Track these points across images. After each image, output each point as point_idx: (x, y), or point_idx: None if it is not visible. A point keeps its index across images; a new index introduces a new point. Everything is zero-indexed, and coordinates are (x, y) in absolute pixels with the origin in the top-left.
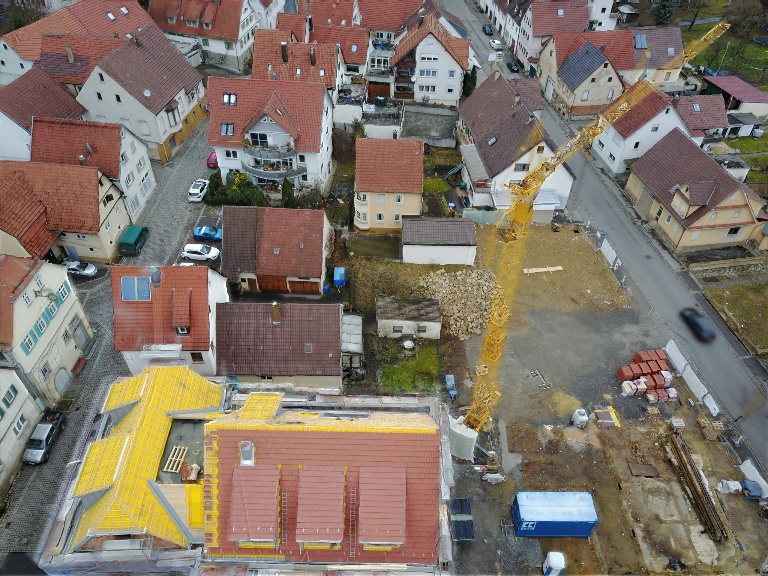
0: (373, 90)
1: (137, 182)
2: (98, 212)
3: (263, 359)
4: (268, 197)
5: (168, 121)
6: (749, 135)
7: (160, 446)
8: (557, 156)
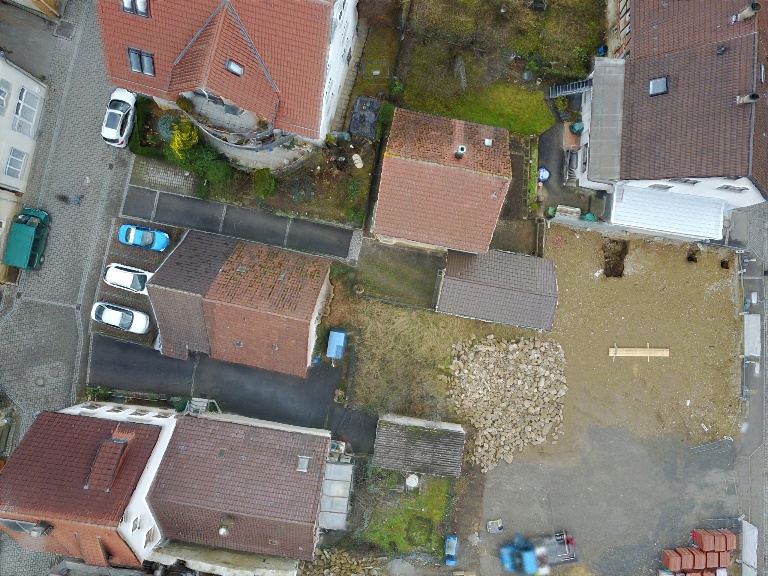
0: None
1: (6, 130)
2: None
3: (216, 538)
4: (234, 163)
5: None
6: None
7: None
8: None
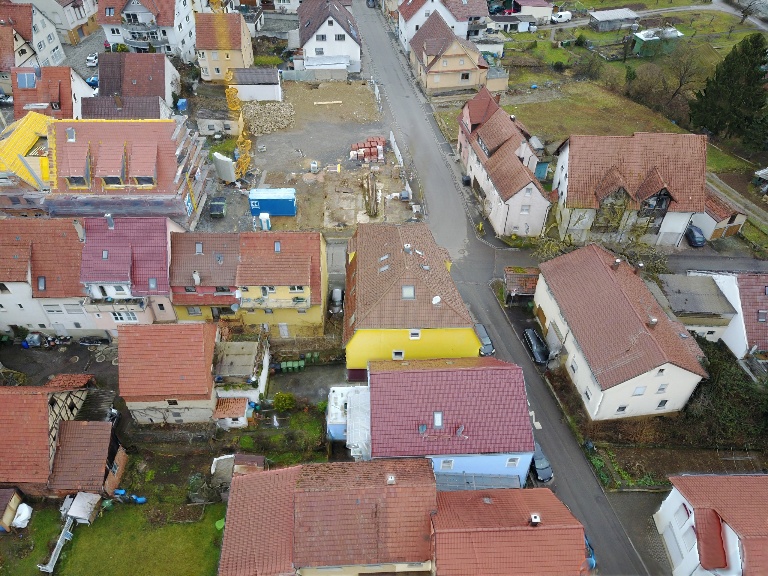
0: (244, 3)
1: (48, 50)
2: (14, 57)
3: None
4: None
5: (75, 15)
6: (528, 31)
7: (29, 144)
8: None
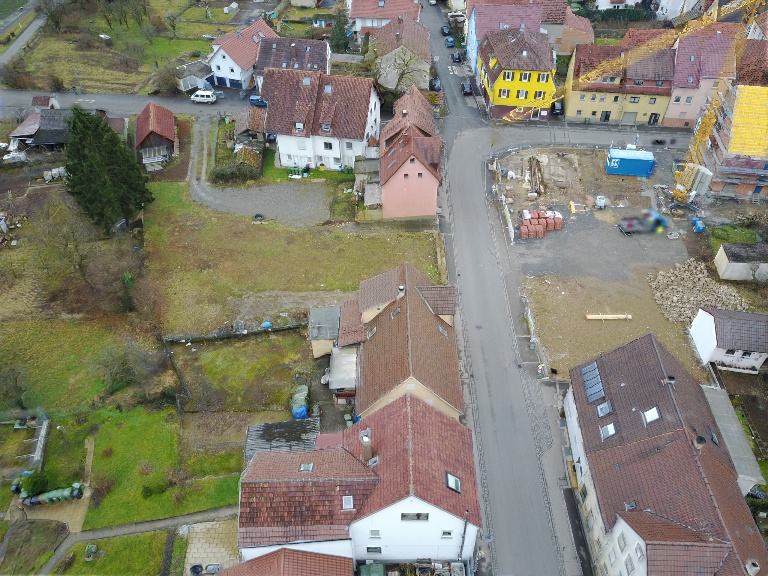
0: None
1: None
2: None
3: None
4: None
5: None
6: None
7: None
8: (743, 1)
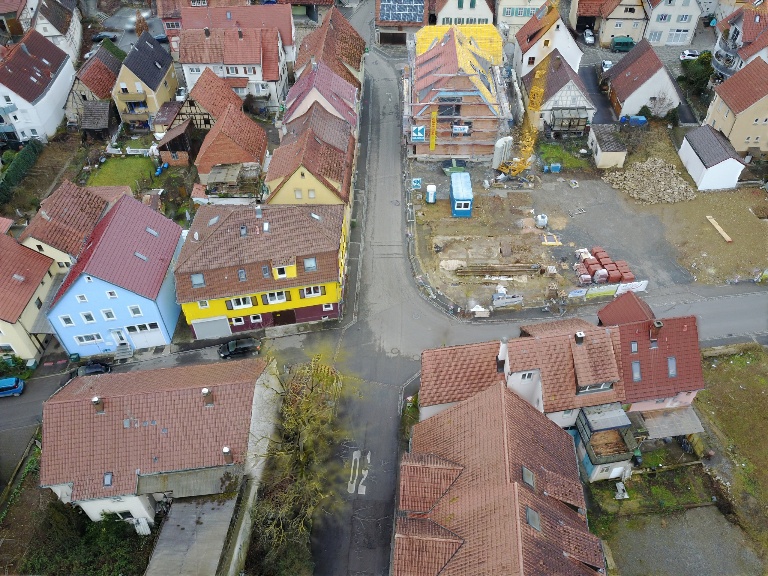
0: None
1: (670, 26)
2: (615, 8)
3: (534, 83)
4: None
5: None
6: None
7: None
8: None
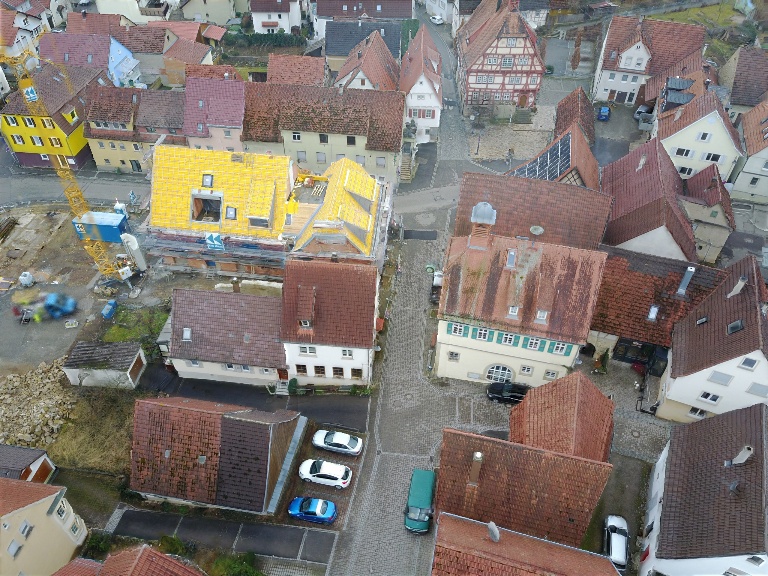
0: None
1: None
2: None
3: None
4: None
5: None
6: None
7: None
8: None
